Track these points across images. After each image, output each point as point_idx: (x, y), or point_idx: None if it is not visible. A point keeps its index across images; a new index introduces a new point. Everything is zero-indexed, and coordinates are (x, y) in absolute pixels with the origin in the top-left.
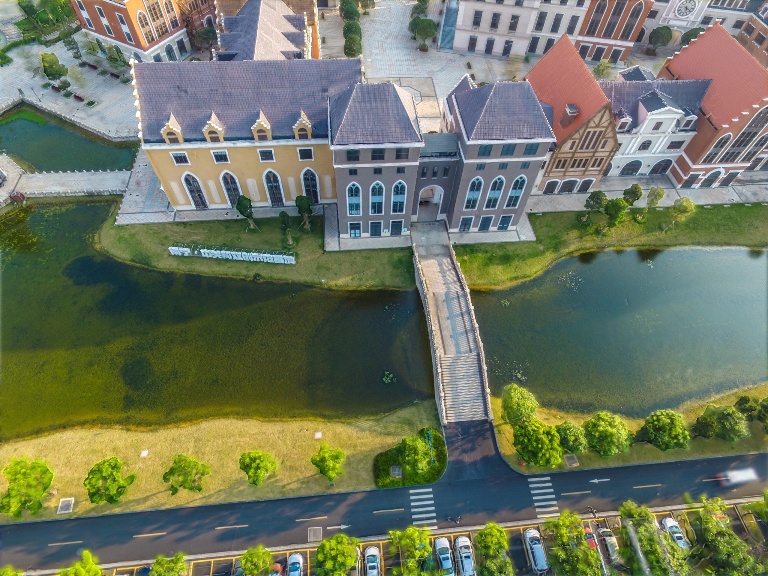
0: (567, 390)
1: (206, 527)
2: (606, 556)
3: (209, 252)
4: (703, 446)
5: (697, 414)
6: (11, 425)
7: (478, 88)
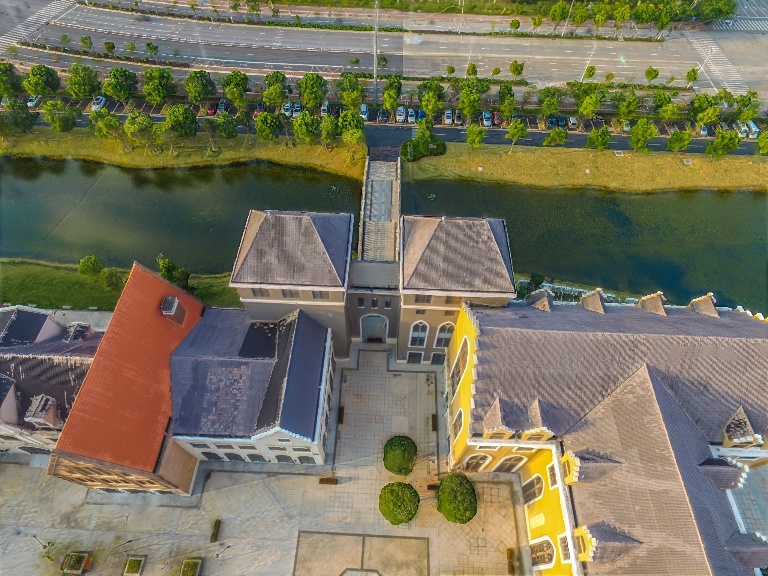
0: (304, 178)
1: (537, 140)
2: (329, 106)
3: (606, 294)
4: (238, 138)
5: (224, 156)
6: (685, 198)
7: (324, 244)
